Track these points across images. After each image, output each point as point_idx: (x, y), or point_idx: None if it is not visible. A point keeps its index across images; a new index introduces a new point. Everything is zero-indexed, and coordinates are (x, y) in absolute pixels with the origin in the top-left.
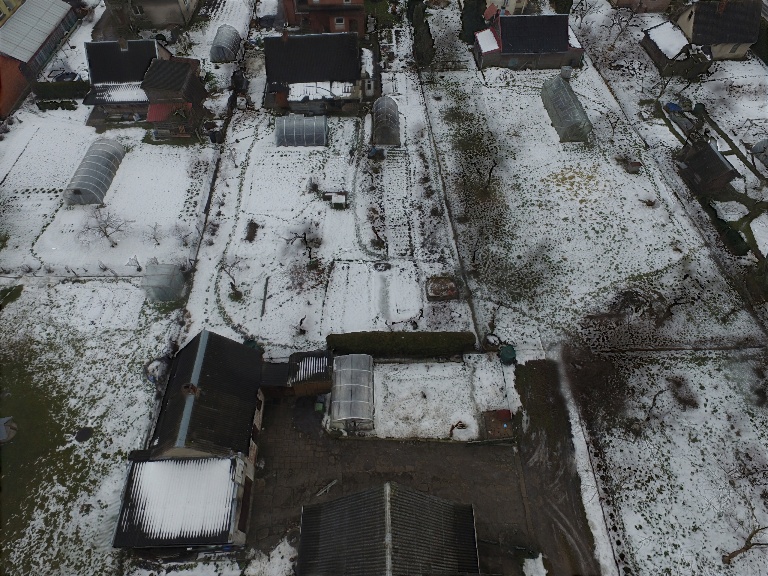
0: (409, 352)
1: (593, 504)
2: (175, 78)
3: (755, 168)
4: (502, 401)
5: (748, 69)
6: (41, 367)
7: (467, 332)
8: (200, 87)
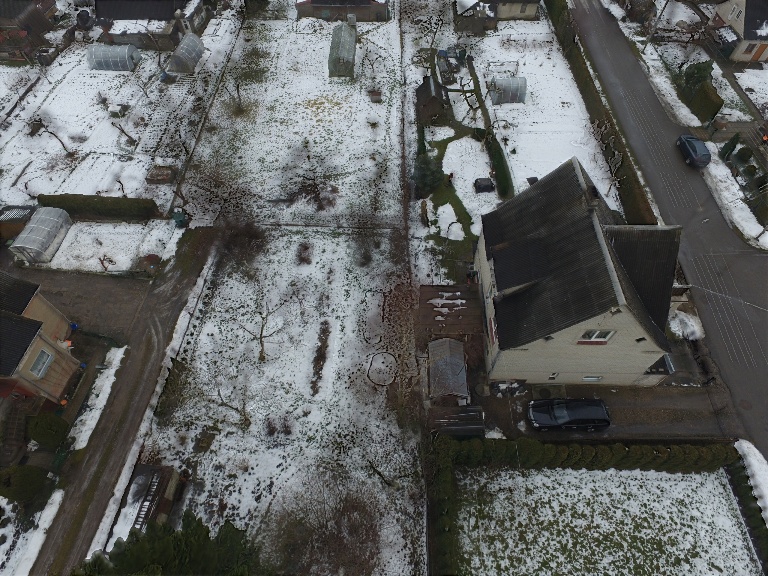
0: (104, 213)
1: (184, 318)
2: (13, 9)
3: None
4: (160, 251)
5: (534, 28)
6: None
7: None
8: (44, 21)
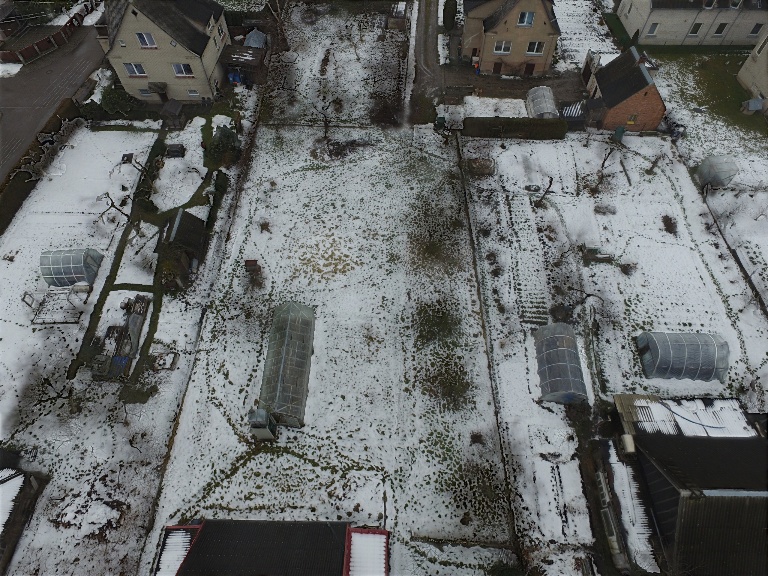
0: None
1: (411, 73)
2: None
3: (141, 228)
4: None
5: None
6: (762, 139)
7: (470, 121)
8: None
